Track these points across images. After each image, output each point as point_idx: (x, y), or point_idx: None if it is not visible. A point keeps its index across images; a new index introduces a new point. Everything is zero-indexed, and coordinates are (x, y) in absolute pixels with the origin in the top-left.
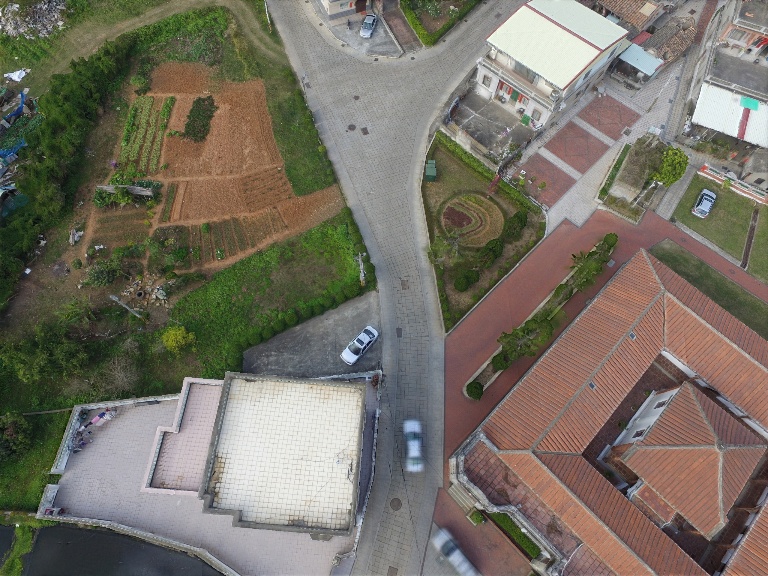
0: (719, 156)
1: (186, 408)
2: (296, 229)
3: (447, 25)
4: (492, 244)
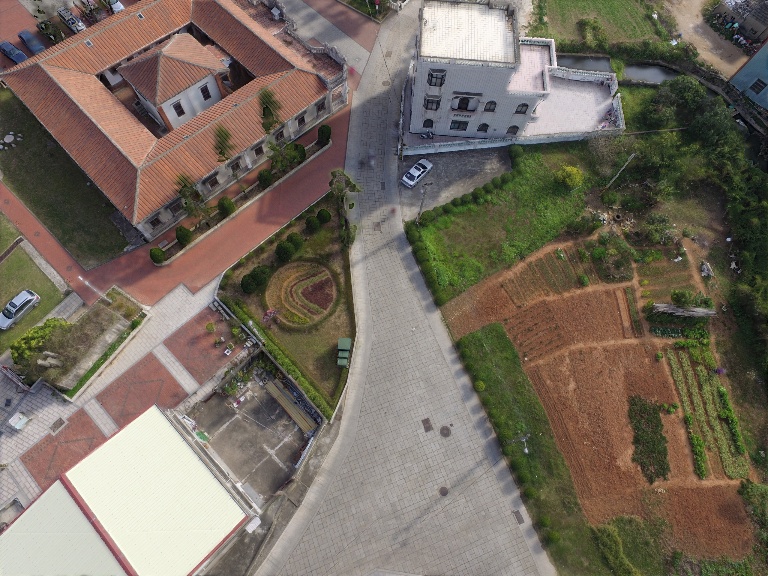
0: None
1: (543, 83)
2: (491, 283)
3: None
4: (289, 244)
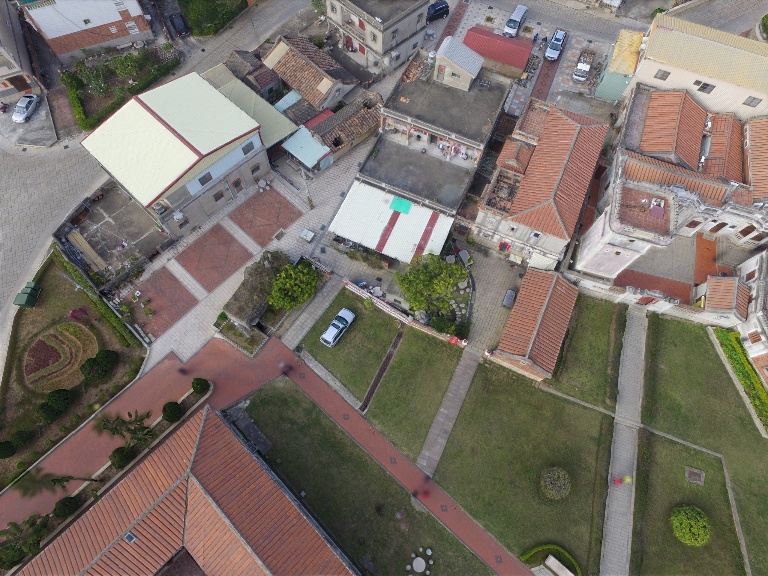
0: (374, 265)
1: None
2: None
3: (110, 106)
4: (46, 399)
